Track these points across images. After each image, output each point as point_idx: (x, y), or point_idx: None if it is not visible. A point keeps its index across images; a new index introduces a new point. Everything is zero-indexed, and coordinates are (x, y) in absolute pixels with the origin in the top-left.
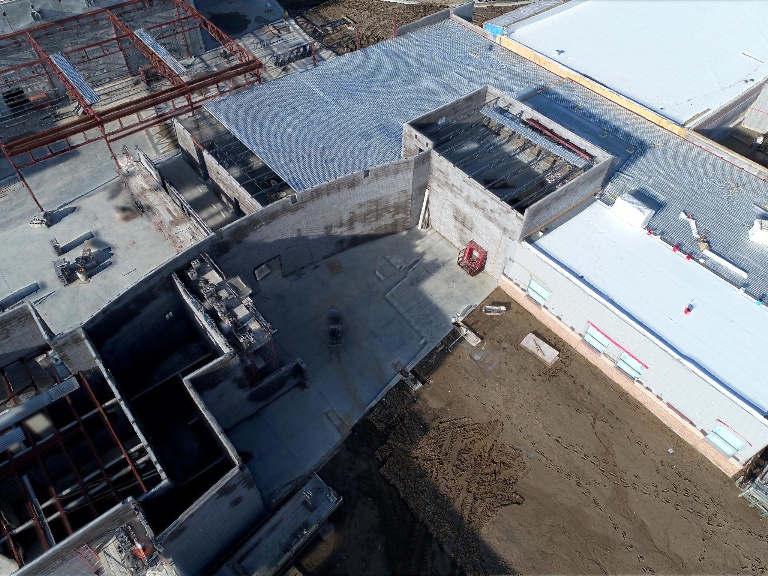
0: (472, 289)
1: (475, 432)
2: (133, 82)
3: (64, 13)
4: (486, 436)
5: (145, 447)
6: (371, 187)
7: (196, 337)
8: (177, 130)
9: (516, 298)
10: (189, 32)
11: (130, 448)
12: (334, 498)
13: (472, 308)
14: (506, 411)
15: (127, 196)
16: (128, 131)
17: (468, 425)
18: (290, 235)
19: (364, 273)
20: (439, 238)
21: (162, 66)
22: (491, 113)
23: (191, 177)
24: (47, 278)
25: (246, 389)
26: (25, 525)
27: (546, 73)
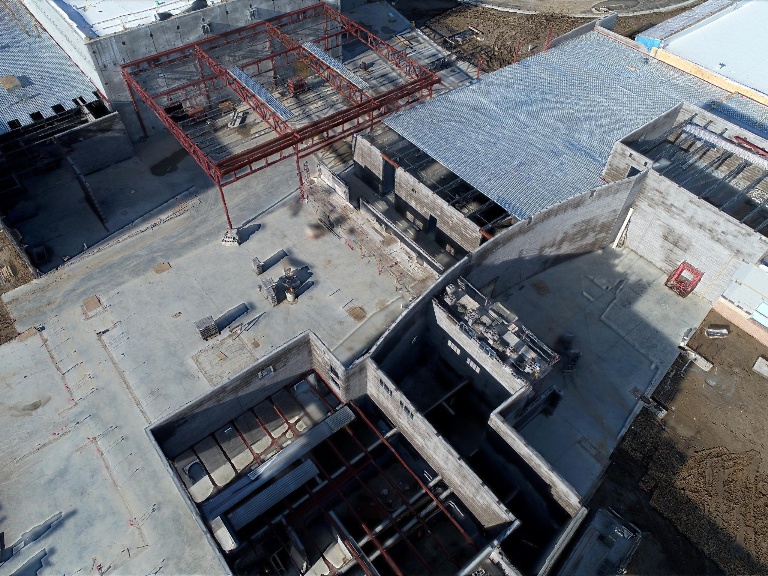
0: (687, 311)
1: (734, 462)
2: (318, 97)
3: (229, 26)
4: (746, 466)
5: (482, 486)
6: (590, 207)
7: (423, 361)
8: (358, 146)
9: (734, 321)
10: (332, 44)
11: (428, 482)
12: (628, 534)
13: (693, 331)
14: (759, 440)
15: (308, 213)
16: (316, 147)
17: (725, 455)
18: (513, 256)
19: (572, 294)
20: (637, 257)
21: (339, 80)
22: (696, 131)
23: (367, 193)
24: (253, 298)
25: (516, 419)
26: (349, 565)
27: (711, 87)
